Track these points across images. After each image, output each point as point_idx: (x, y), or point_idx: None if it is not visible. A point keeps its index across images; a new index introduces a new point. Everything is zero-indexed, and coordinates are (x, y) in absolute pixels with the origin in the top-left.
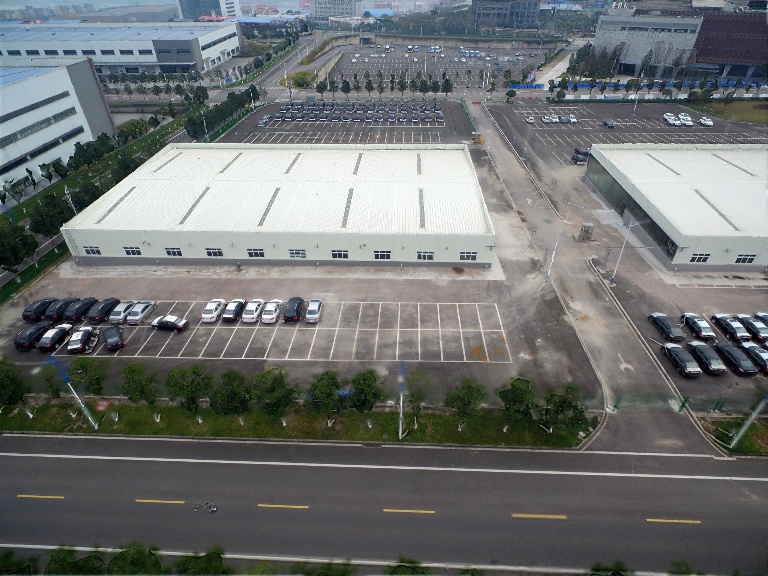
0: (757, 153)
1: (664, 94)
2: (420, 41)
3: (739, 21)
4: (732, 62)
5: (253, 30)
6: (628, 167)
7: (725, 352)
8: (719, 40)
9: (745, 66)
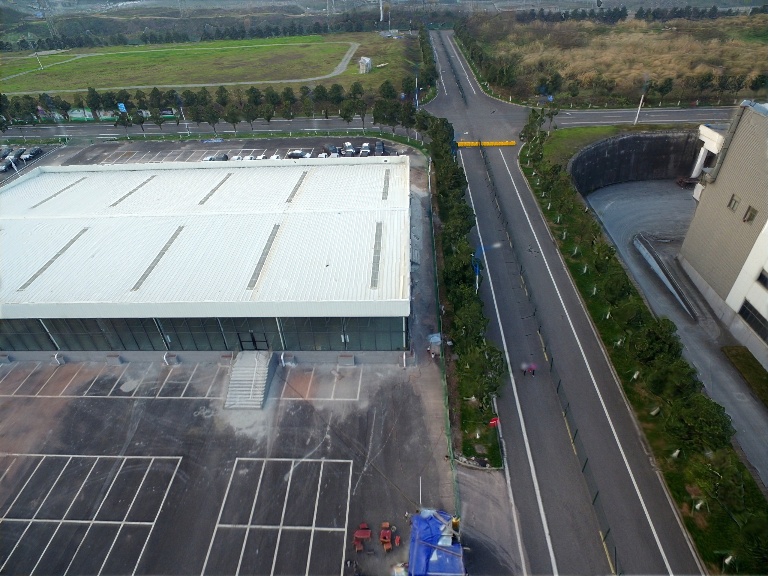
0: None
1: None
2: None
3: None
4: None
5: None
6: None
7: (5, 154)
8: None
9: None
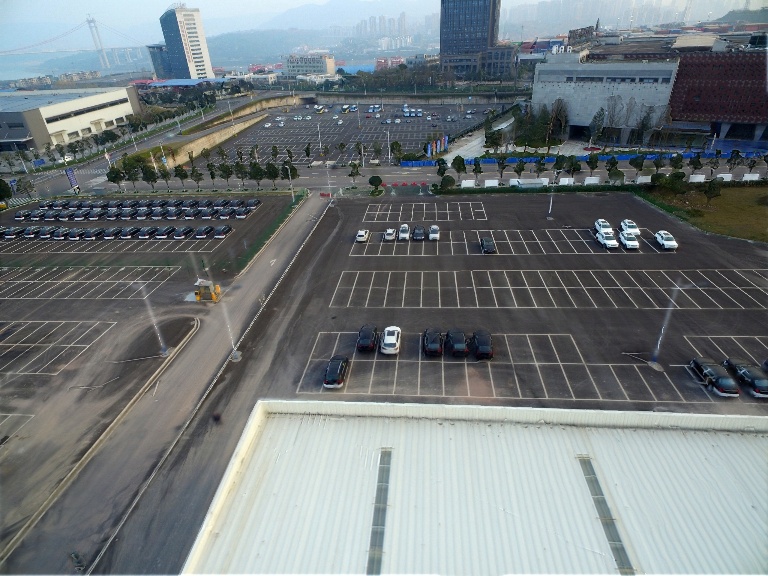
0: (724, 465)
1: (611, 178)
2: (364, 99)
3: (735, 64)
4: (731, 119)
5: (176, 93)
6: (234, 572)
7: None
8: (709, 90)
9: (751, 125)
